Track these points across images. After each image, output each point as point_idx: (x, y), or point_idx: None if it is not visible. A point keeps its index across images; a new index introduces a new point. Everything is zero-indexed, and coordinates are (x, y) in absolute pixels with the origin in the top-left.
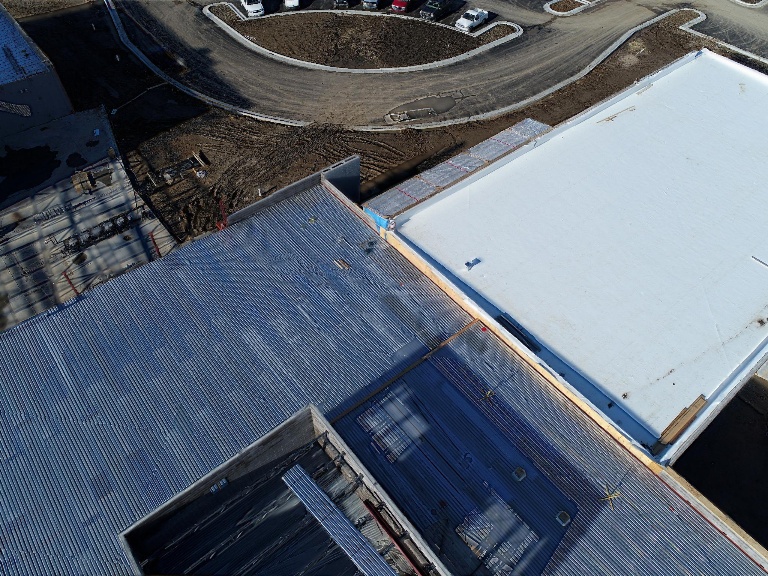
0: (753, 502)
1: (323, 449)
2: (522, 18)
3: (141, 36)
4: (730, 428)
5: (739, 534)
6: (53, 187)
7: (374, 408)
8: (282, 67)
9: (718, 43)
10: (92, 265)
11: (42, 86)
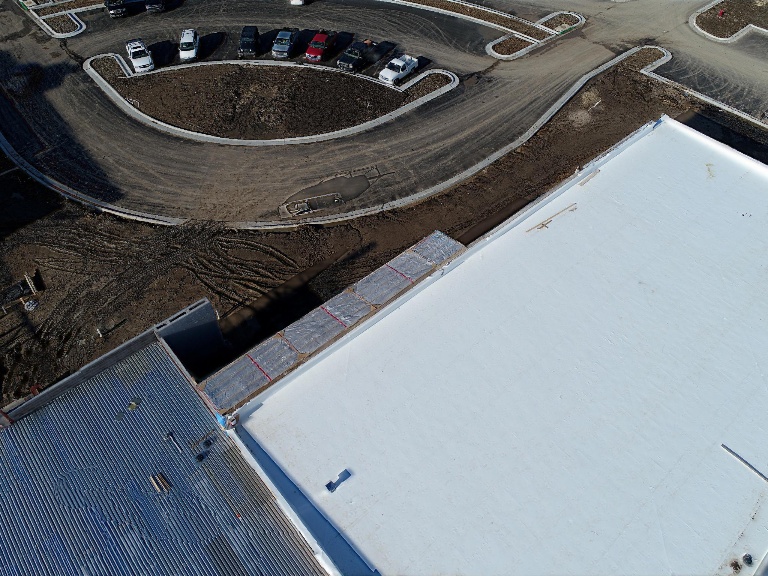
0: None
1: None
2: (459, 64)
3: (1, 102)
4: None
5: None
6: None
7: None
8: (164, 140)
9: (685, 91)
10: None
11: None
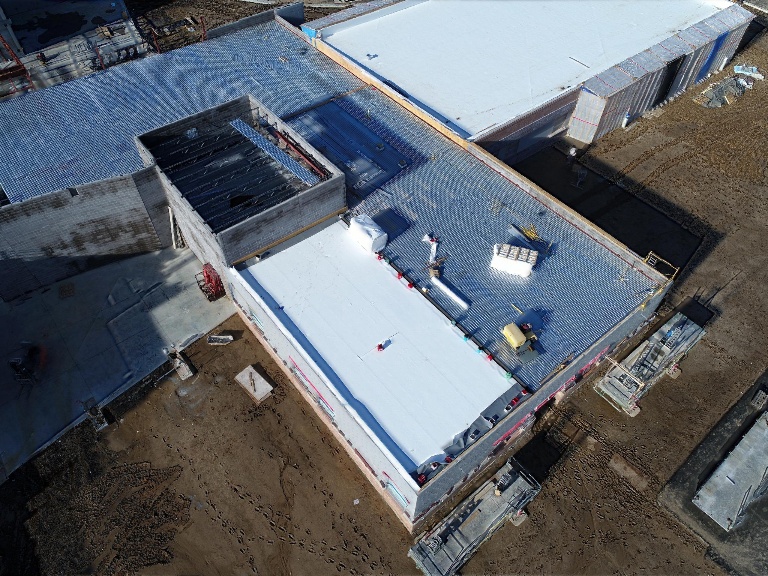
0: None
1: None
2: None
3: None
4: (542, 161)
5: (505, 167)
6: (82, 35)
7: (294, 120)
8: None
9: None
10: None
11: None
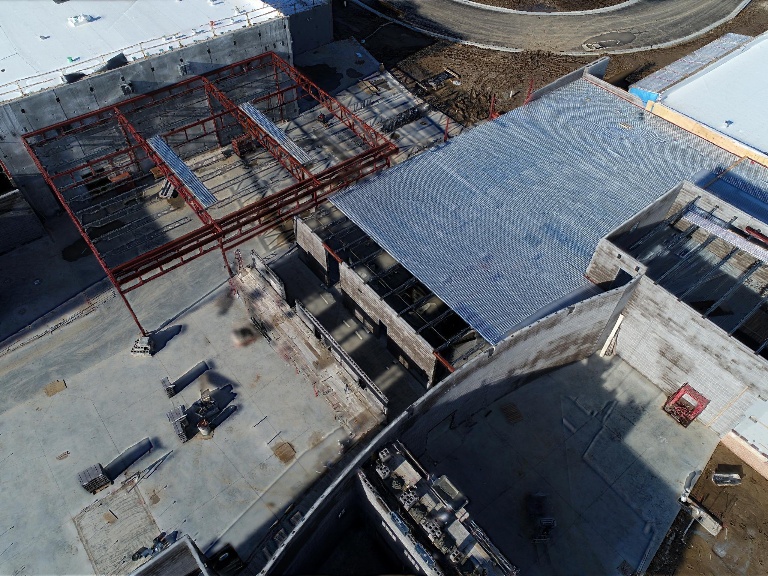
0: None
1: (671, 225)
2: None
3: None
4: None
5: None
6: (347, 91)
7: None
8: (480, 11)
9: None
10: (406, 140)
11: (320, 16)
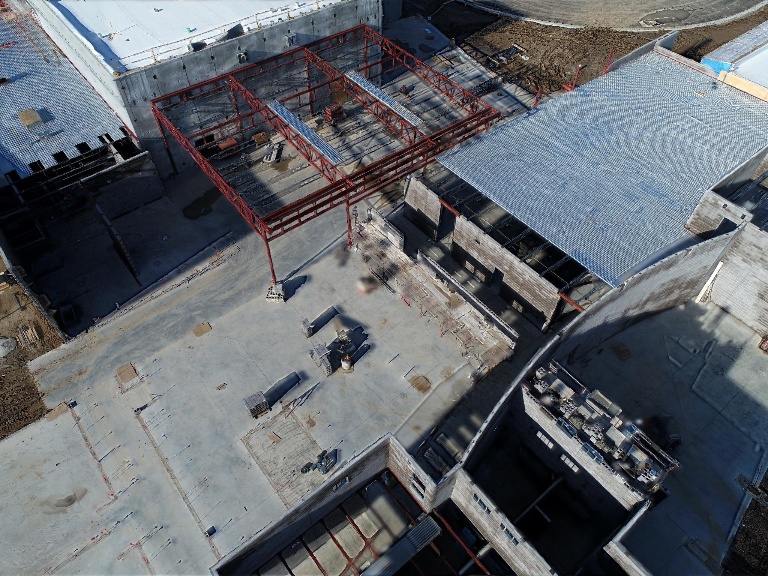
0: None
1: None
2: None
3: None
4: None
5: None
6: (422, 65)
7: None
8: None
9: None
10: None
11: None
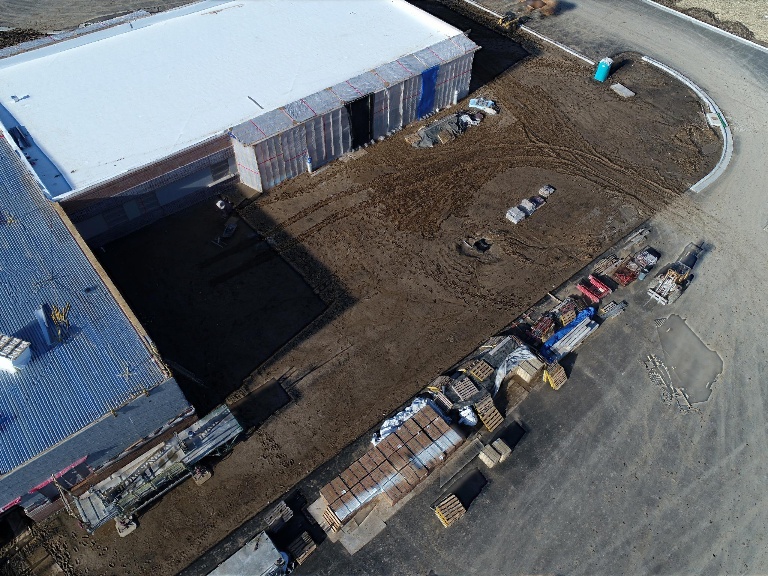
0: (178, 252)
1: None
2: None
3: None
4: (197, 213)
5: (72, 233)
6: None
7: None
8: None
9: None
10: None
11: None
